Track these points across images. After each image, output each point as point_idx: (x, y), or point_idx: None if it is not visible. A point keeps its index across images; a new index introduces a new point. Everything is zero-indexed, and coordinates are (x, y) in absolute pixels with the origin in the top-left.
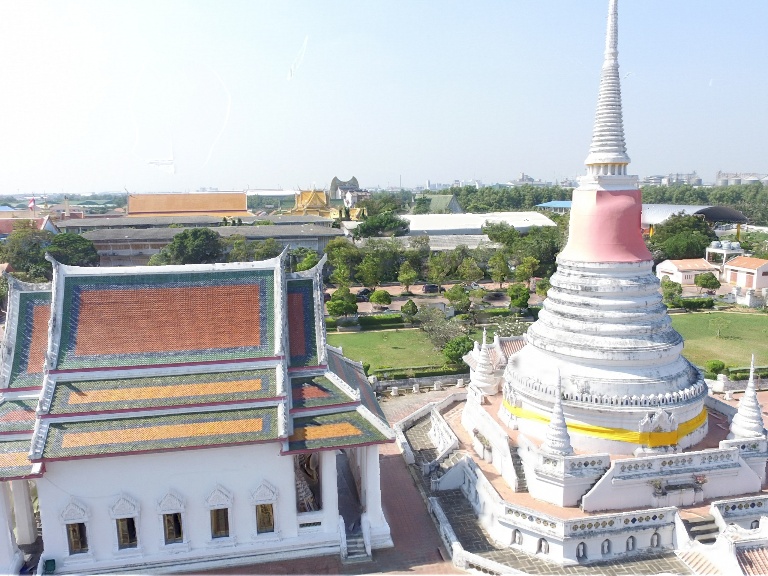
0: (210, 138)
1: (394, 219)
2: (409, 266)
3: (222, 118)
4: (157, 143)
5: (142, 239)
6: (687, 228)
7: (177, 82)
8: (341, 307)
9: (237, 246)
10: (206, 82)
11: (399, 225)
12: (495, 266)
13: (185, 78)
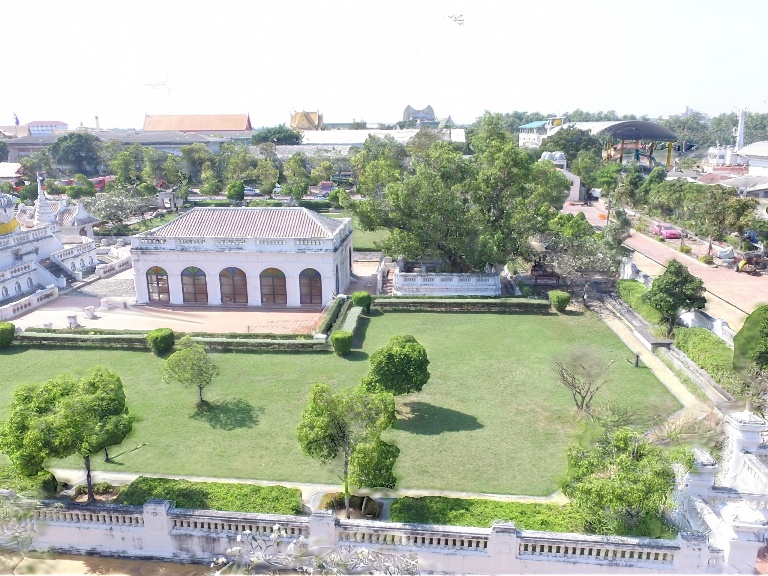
0: (201, 61)
1: (283, 131)
2: (209, 166)
3: (214, 41)
4: (151, 66)
5: (50, 143)
6: (563, 142)
7: (170, 8)
8: (72, 190)
9: (107, 149)
10: (199, 7)
11: (286, 136)
12: (289, 169)
13: (178, 4)
